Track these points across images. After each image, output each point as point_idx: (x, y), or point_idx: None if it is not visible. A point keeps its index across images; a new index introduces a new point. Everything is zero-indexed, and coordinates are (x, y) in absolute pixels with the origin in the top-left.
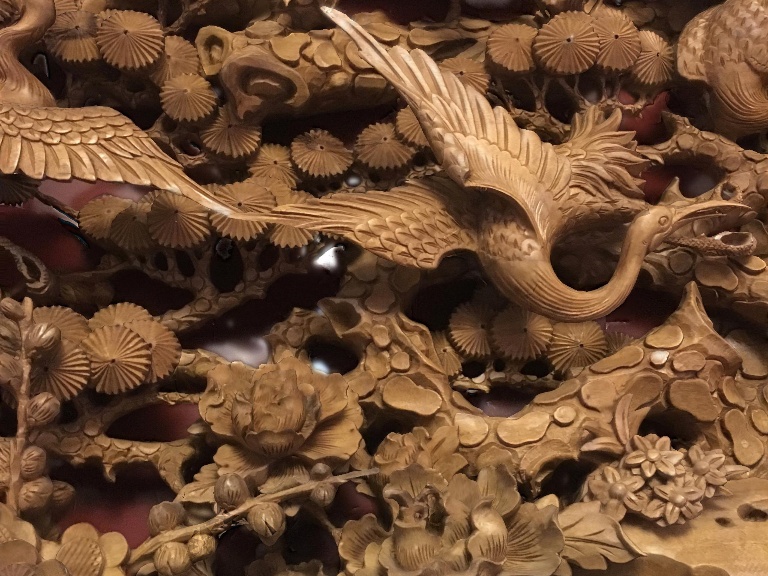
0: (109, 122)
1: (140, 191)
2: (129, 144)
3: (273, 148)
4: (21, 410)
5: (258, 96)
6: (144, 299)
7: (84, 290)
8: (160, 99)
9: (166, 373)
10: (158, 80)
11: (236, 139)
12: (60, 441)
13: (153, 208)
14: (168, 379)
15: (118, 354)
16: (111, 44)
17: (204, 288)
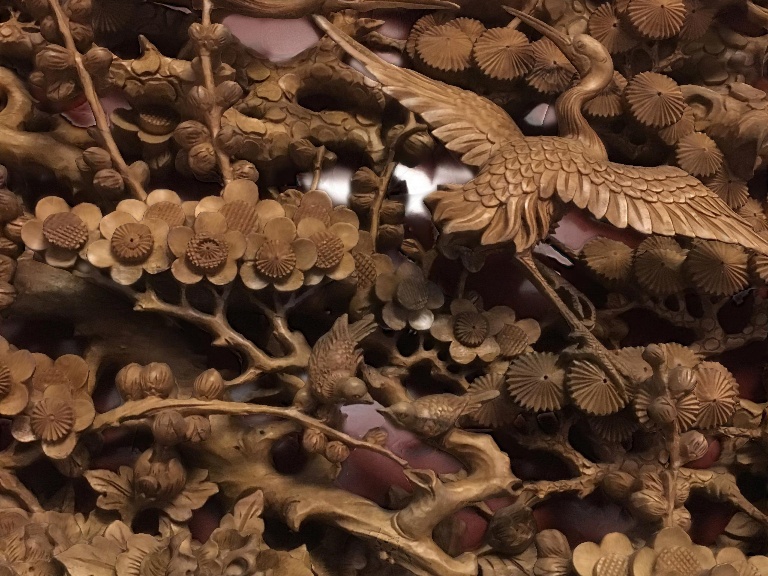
0: (686, 182)
1: (615, 232)
2: (708, 204)
3: (749, 201)
4: (676, 446)
5: (760, 156)
6: (655, 336)
7: (608, 327)
8: (676, 155)
9: (733, 410)
10: (665, 136)
11: (734, 194)
12: (639, 468)
13: (693, 258)
14: (733, 415)
15: (717, 394)
16: (644, 104)
17: (715, 329)
